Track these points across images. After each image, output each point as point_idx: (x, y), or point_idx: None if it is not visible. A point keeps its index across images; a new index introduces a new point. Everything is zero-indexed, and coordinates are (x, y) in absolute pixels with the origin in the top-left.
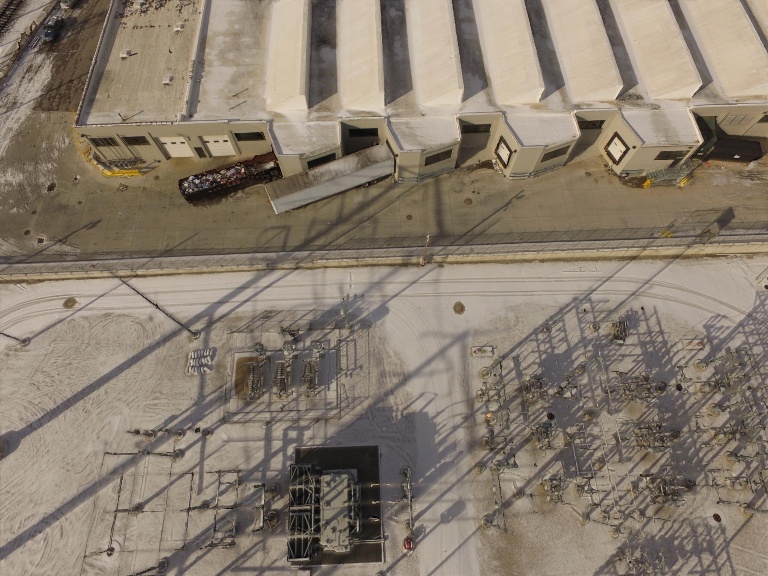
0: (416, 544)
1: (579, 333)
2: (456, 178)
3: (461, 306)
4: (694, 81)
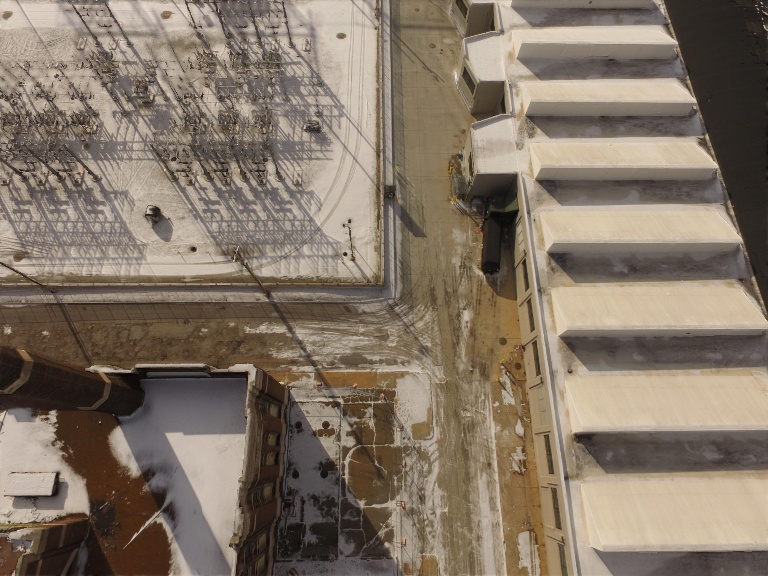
0: (195, 3)
1: (315, 103)
2: (456, 40)
3: (343, 37)
4: (544, 162)
